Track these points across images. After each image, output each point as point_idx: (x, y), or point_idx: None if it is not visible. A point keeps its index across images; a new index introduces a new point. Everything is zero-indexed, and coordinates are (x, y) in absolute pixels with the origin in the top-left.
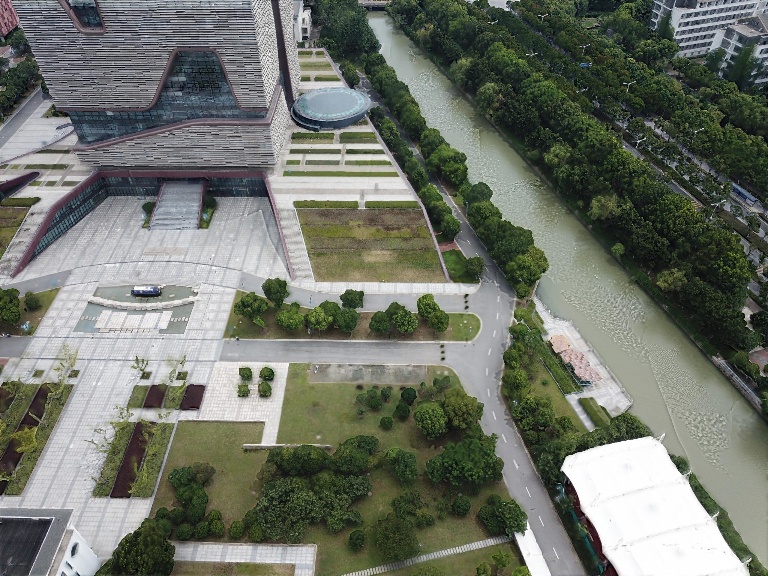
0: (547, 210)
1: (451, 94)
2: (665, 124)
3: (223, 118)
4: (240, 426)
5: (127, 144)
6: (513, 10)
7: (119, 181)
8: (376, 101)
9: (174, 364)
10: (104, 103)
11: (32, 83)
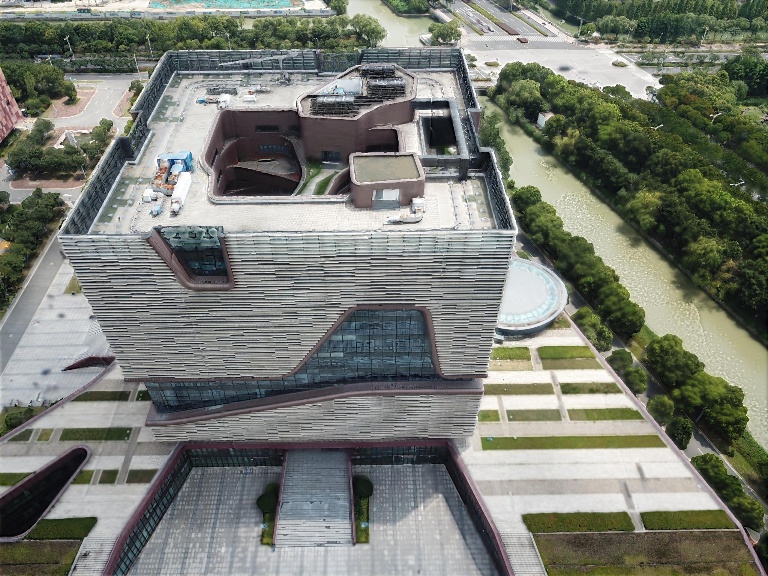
0: None
1: (627, 237)
2: None
3: (404, 382)
4: None
5: (238, 417)
6: (659, 100)
7: (213, 451)
8: (535, 255)
9: None
10: (209, 372)
11: (44, 231)
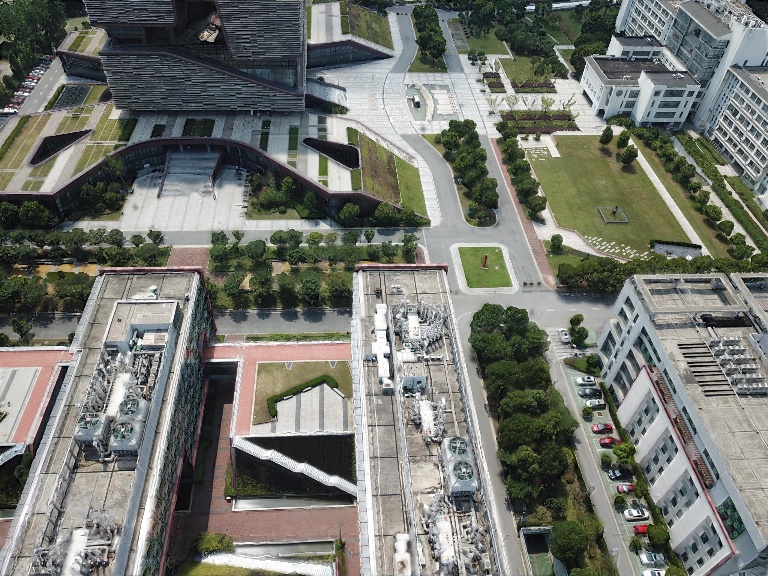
0: None
1: None
2: None
3: None
4: (502, 63)
5: None
6: None
7: None
8: None
9: (472, 84)
10: None
11: None
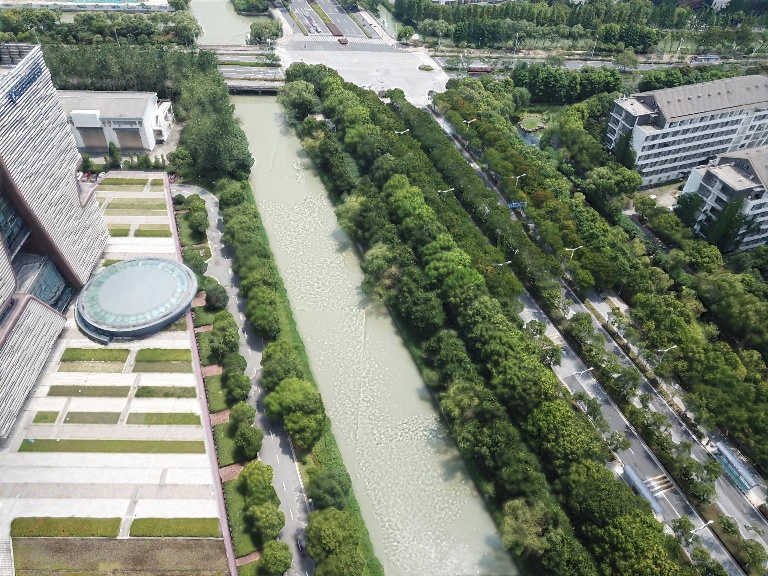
0: (443, 487)
1: (338, 241)
2: (622, 321)
3: None
4: None
5: None
6: (435, 105)
7: None
8: (229, 257)
9: None
10: None
11: None
